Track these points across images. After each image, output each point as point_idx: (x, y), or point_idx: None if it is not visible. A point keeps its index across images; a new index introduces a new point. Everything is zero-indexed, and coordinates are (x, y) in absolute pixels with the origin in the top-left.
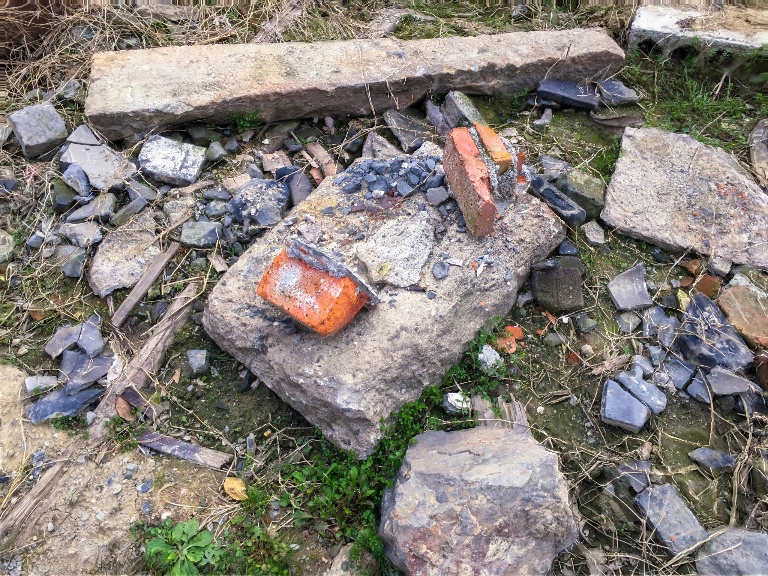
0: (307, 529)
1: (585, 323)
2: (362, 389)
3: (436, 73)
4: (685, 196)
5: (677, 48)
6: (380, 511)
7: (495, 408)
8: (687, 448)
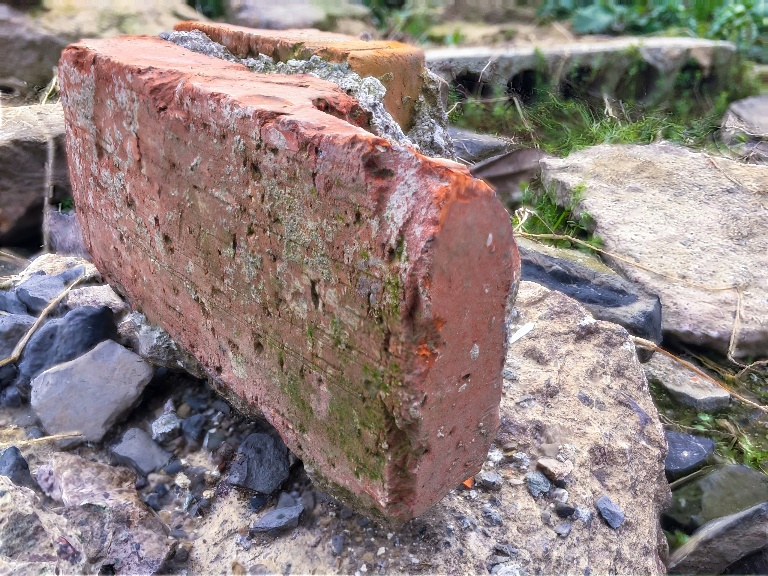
0: None
1: None
2: None
3: (52, 135)
4: None
5: (516, 73)
6: None
7: None
8: None
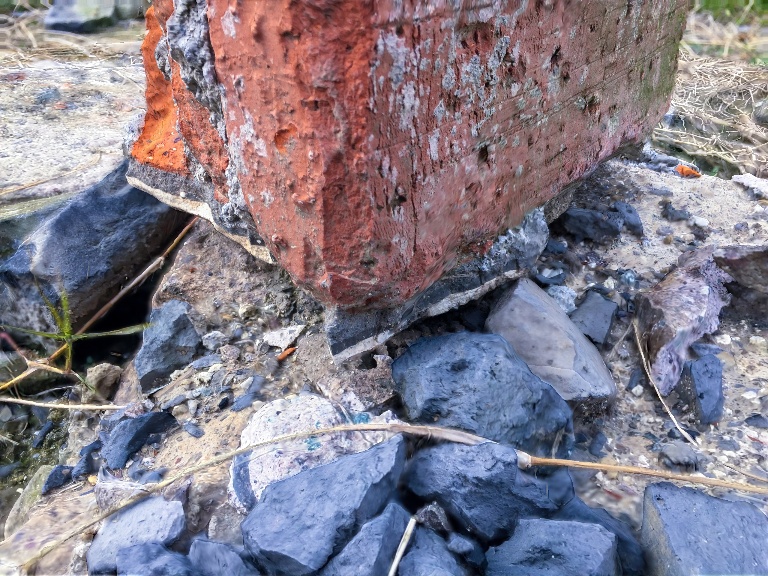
0: None
1: None
2: None
3: None
4: (5, 113)
5: None
6: None
7: None
8: None
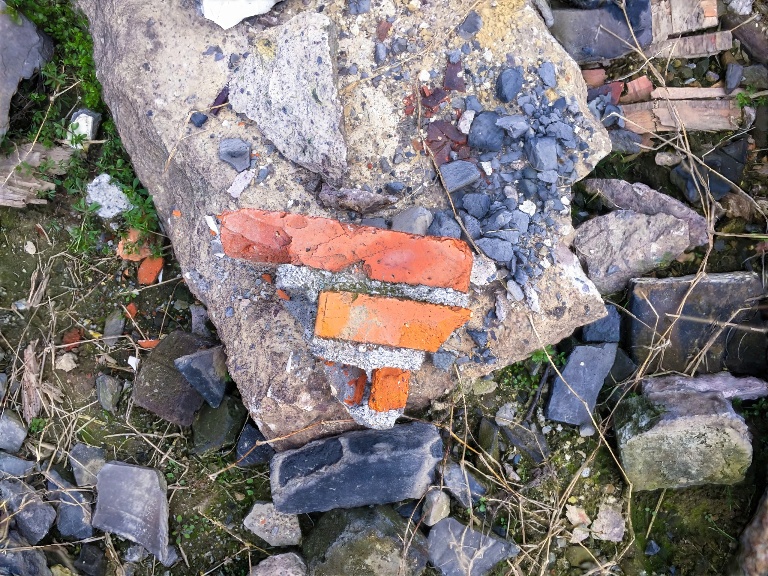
0: None
1: (104, 384)
2: None
3: None
4: None
5: None
6: None
7: (43, 173)
8: None
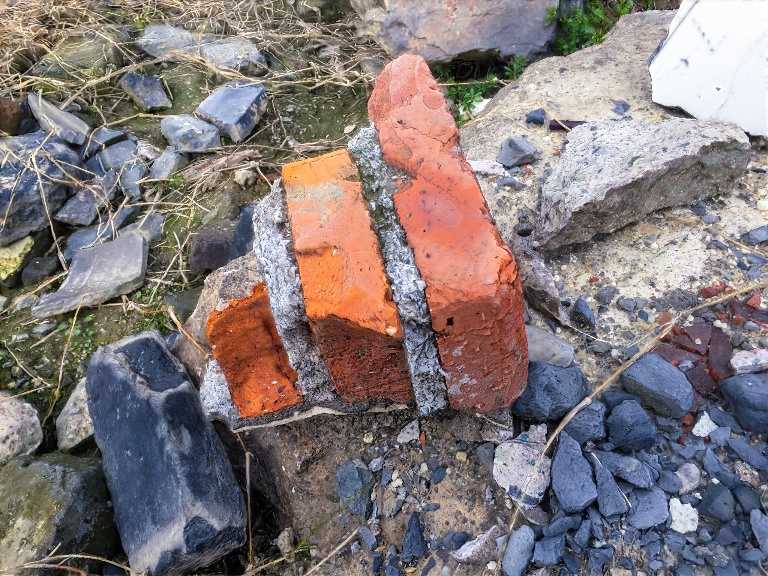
0: None
1: None
2: None
3: None
4: None
5: None
6: (583, 8)
7: None
8: None
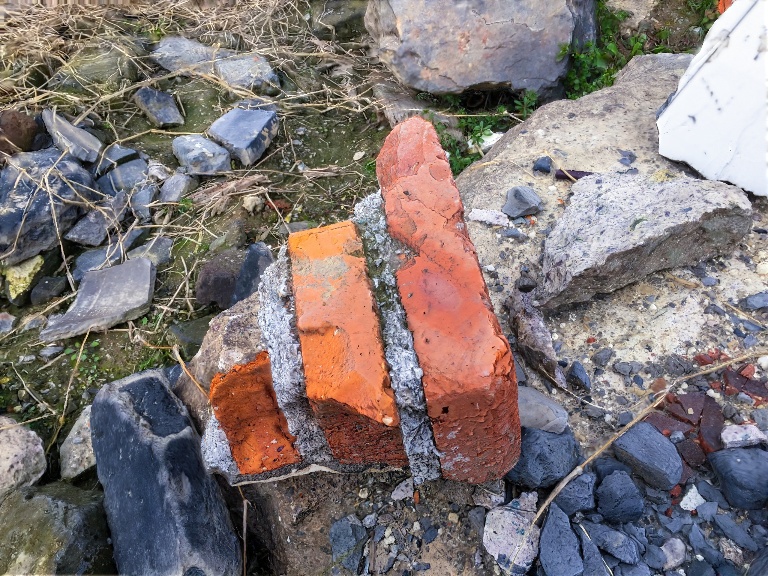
0: (685, 45)
1: None
2: (655, 68)
3: None
4: None
5: None
6: None
7: None
8: (180, 130)
